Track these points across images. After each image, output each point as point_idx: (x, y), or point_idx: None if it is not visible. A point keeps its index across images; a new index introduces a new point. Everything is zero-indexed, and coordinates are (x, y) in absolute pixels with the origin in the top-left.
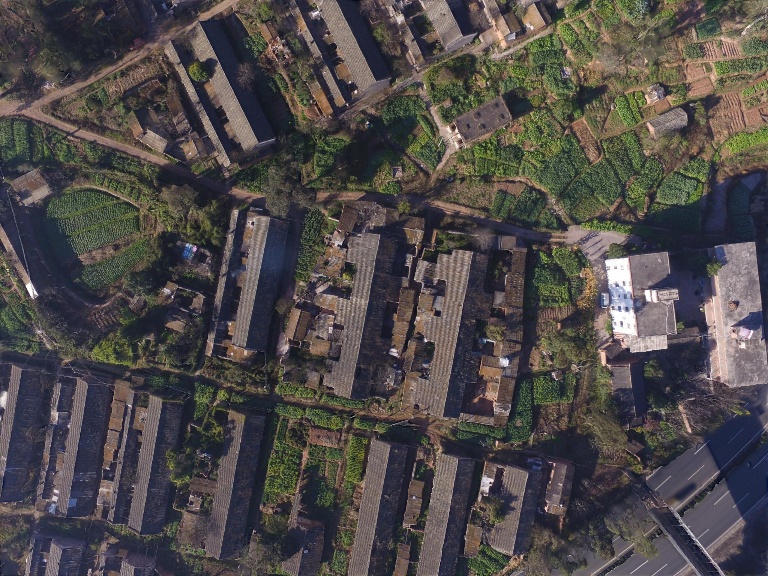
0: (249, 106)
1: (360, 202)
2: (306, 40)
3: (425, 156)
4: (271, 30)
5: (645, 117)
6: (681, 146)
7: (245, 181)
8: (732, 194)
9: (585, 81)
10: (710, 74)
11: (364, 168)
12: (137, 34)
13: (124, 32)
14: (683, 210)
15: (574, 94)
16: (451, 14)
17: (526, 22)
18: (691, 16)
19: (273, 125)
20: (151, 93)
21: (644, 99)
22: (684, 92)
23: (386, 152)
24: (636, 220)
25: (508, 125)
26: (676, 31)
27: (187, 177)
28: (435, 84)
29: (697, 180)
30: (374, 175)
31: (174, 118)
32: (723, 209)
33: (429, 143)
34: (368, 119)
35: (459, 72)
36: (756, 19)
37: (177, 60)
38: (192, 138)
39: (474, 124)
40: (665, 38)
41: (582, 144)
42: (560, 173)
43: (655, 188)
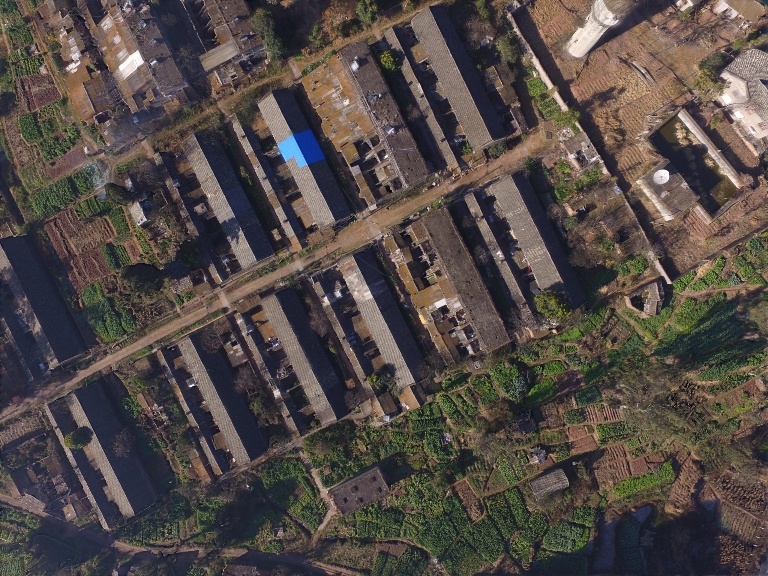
0: (126, 474)
1: (240, 567)
2: (183, 409)
3: (306, 519)
4: (148, 399)
5: (528, 474)
6: (566, 498)
7: (127, 537)
8: (622, 528)
9: (465, 446)
10: (592, 434)
11: (246, 526)
12: (15, 393)
13: (1, 391)
14: (569, 558)
15: (455, 457)
16: (325, 397)
17: (402, 401)
18: (570, 385)
19: (155, 480)
20: (30, 452)
21: (526, 459)
22: (566, 452)
23: (267, 512)
24: (520, 572)
25: (389, 487)
26: (556, 398)
27: (69, 529)
28: (314, 452)
29: (583, 526)
30: (256, 533)
31: (53, 479)
32: (611, 548)
33: (310, 504)
34: (248, 482)
35: (339, 438)
36: (630, 406)
37: (54, 424)
38: (71, 500)
39: (351, 498)
40: (545, 404)
41: (464, 504)
42: (441, 535)
43: (540, 538)
